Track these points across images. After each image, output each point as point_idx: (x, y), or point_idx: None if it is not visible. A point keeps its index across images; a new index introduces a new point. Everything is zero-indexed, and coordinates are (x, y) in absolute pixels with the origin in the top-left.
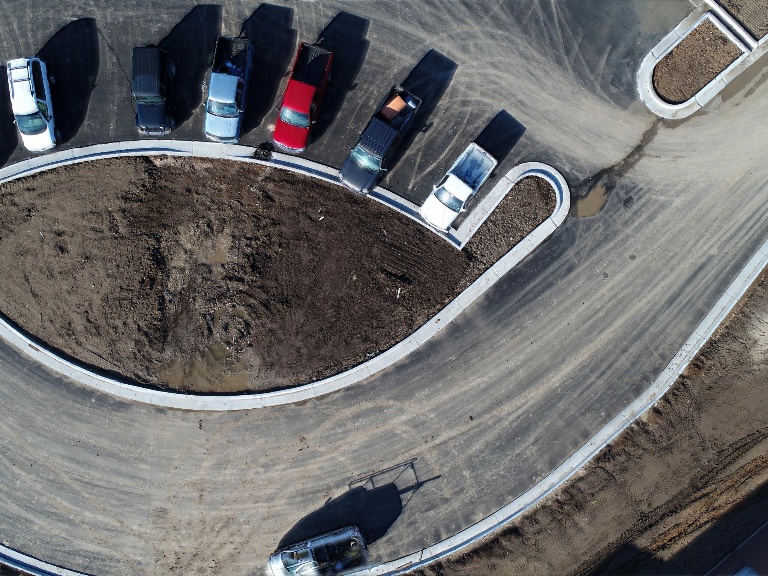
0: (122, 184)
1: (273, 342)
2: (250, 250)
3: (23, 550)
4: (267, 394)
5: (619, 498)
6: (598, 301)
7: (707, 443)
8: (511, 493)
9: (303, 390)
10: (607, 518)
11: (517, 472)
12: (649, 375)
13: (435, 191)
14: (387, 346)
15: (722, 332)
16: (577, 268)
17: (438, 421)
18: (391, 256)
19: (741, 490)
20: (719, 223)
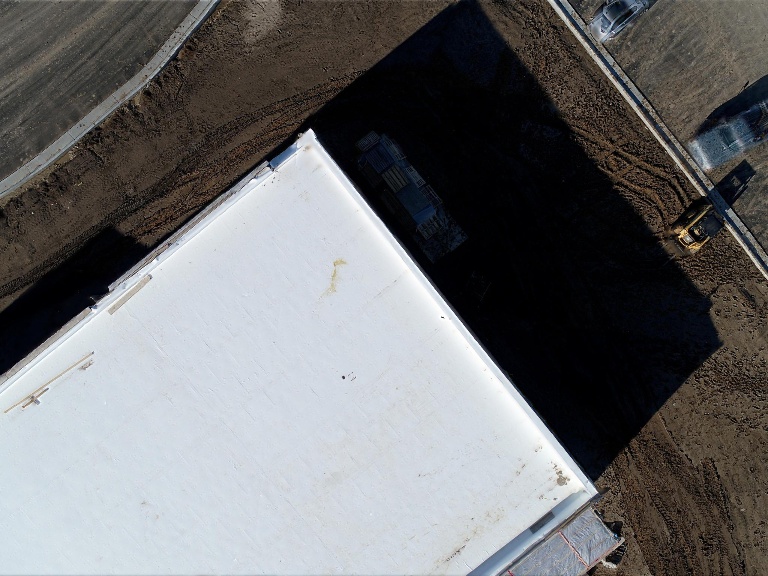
0: None
1: None
2: None
3: None
4: None
5: (105, 180)
6: None
7: (195, 126)
8: None
9: None
10: (92, 200)
11: (4, 153)
12: (142, 57)
13: None
14: None
15: (219, 16)
16: None
17: None
18: None
19: (230, 175)
20: None
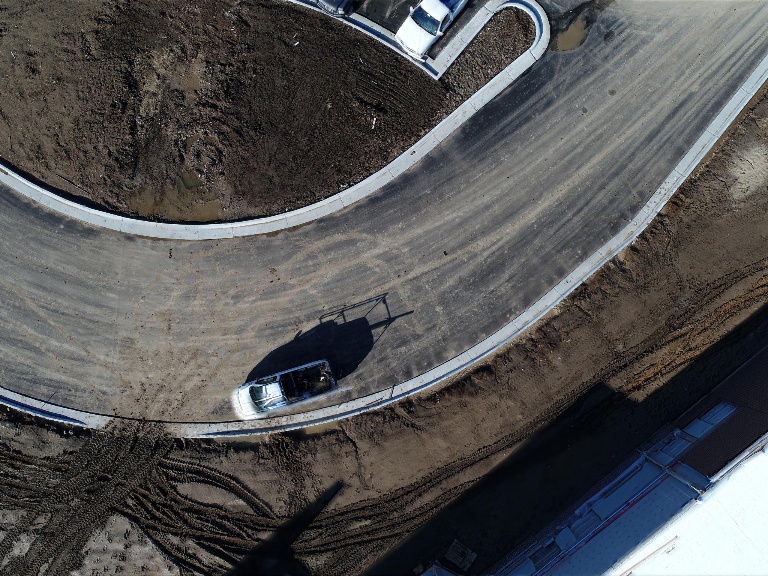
0: (95, 5)
1: (245, 170)
2: (224, 76)
3: None
4: (238, 223)
5: (594, 337)
6: (576, 137)
7: (685, 282)
8: (484, 331)
9: (275, 221)
10: (581, 357)
11: (491, 309)
12: (627, 213)
13: (412, 13)
14: (361, 178)
15: (702, 171)
16: (556, 102)
17: (412, 255)
18: (367, 84)
19: (718, 331)
20: (701, 59)
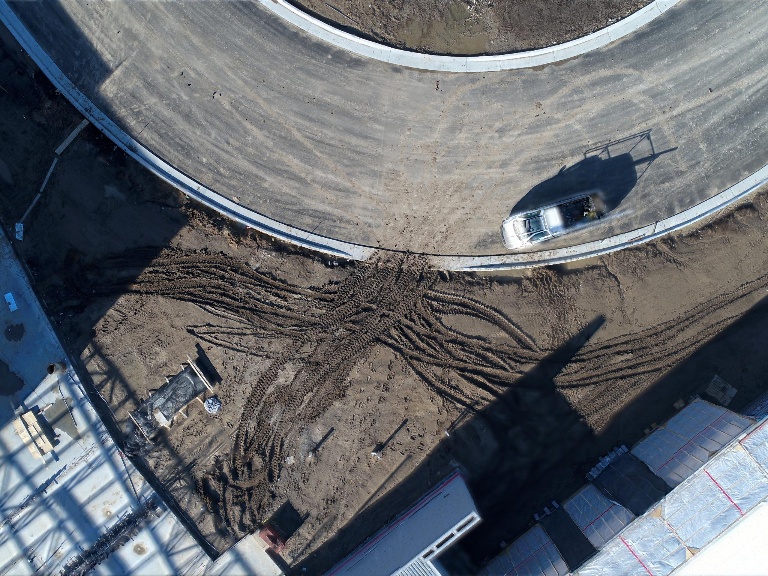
0: None
1: (515, 3)
2: None
3: (253, 207)
4: (507, 55)
5: None
6: None
7: None
8: (747, 168)
9: (542, 54)
10: None
11: (754, 147)
12: None
13: None
14: (629, 13)
15: None
16: None
17: (677, 92)
18: None
19: None
20: None
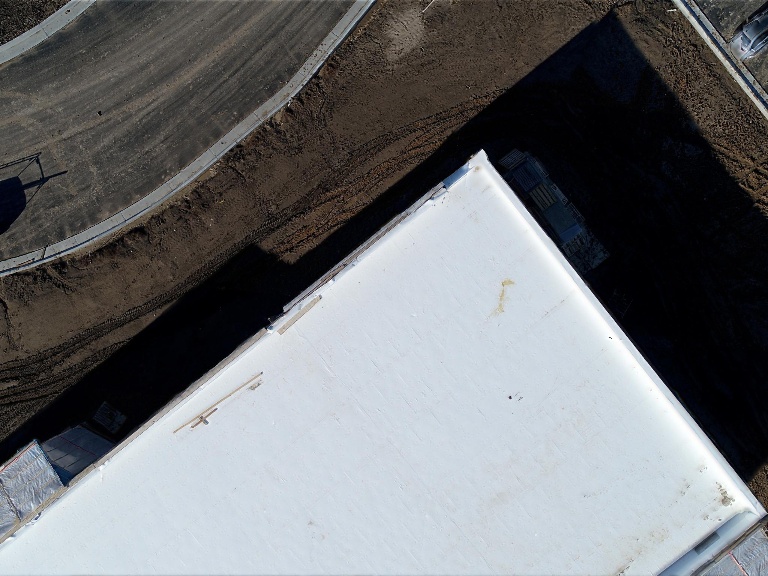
0: None
1: None
2: None
3: None
4: None
5: (247, 198)
6: None
7: (338, 143)
8: (139, 192)
9: None
10: (234, 218)
11: (146, 170)
12: (284, 75)
13: None
14: (15, 36)
15: (360, 34)
16: None
17: (66, 115)
18: None
19: (372, 193)
20: None
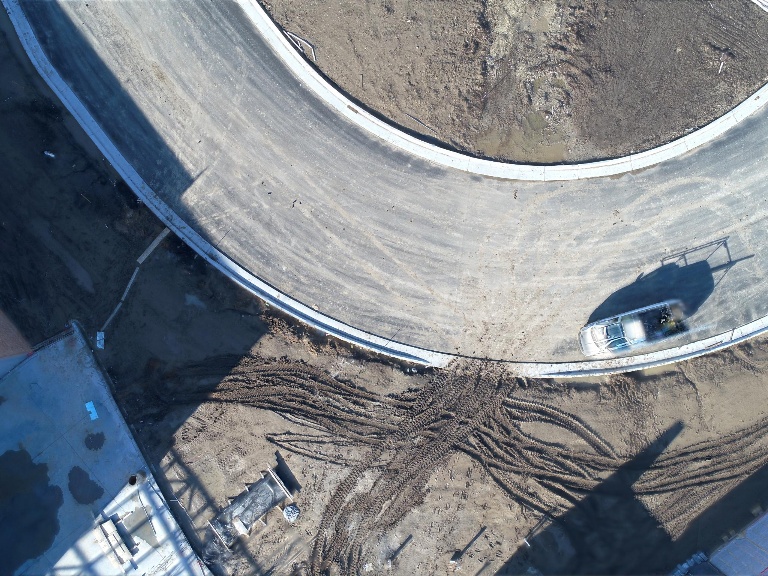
0: None
1: (593, 113)
2: (573, 19)
3: (332, 315)
4: (585, 165)
5: None
6: None
7: None
8: None
9: (620, 163)
10: None
11: None
12: None
13: None
14: (705, 122)
15: None
16: None
17: (753, 200)
18: (716, 29)
19: None
20: None
